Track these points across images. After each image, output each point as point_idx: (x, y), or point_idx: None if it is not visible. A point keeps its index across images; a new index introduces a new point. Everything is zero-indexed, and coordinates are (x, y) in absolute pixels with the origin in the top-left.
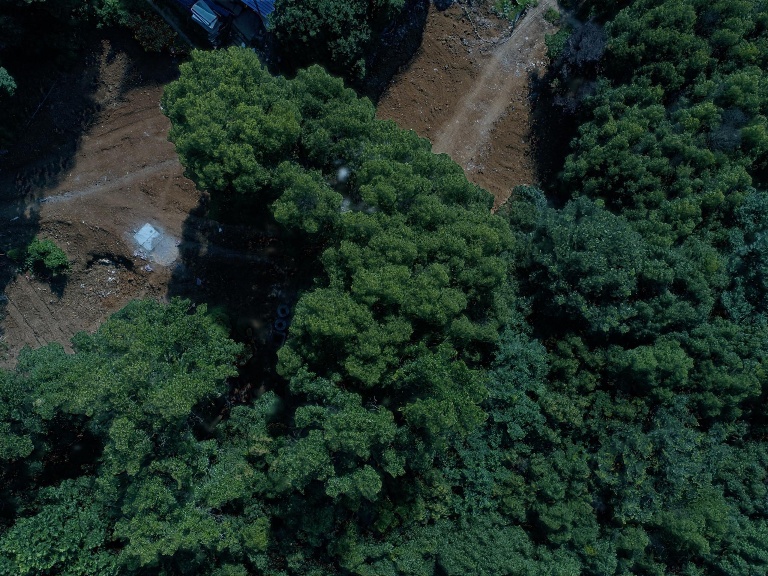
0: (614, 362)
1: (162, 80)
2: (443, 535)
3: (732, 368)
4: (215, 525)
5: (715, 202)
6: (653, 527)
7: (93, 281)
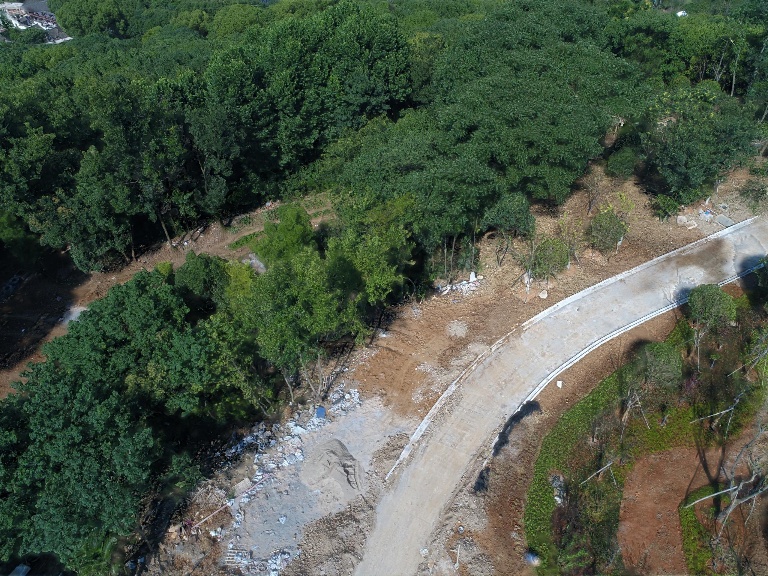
0: None
1: None
2: None
3: None
4: None
5: None
6: None
7: None
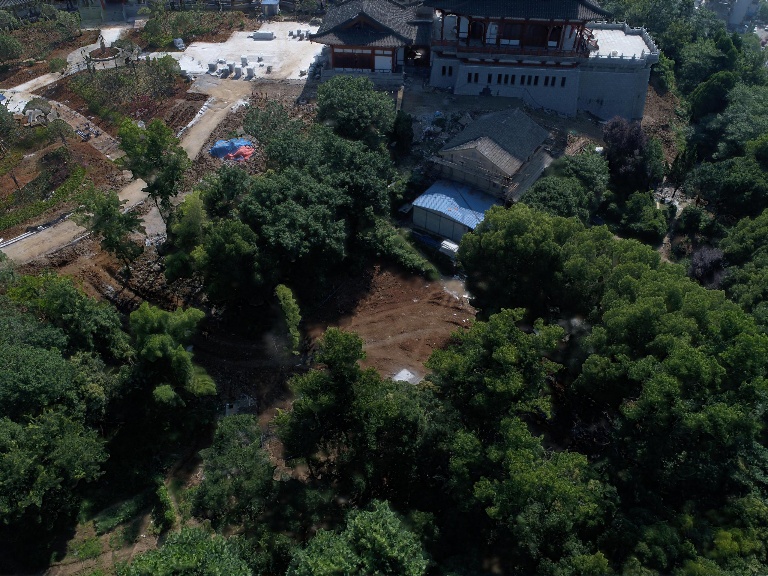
0: None
1: (414, 287)
2: None
3: None
4: None
5: None
6: None
7: None
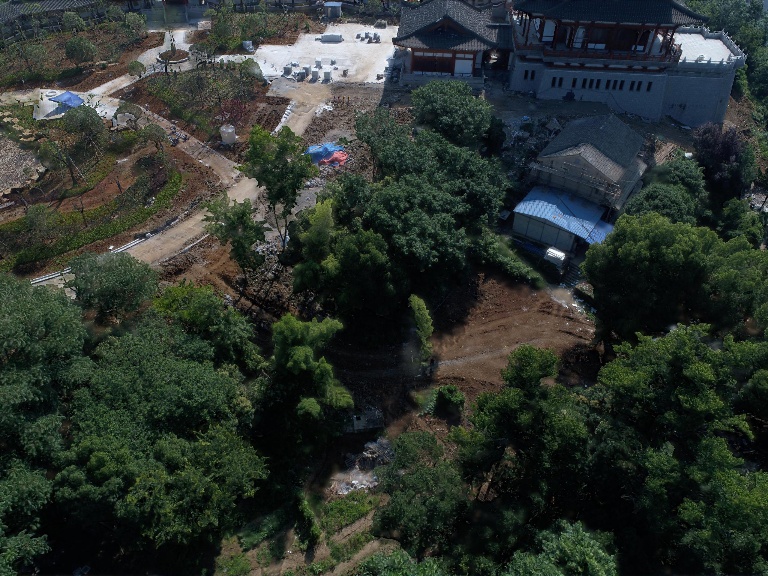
0: None
1: (521, 295)
2: None
3: None
4: None
5: None
6: None
7: None
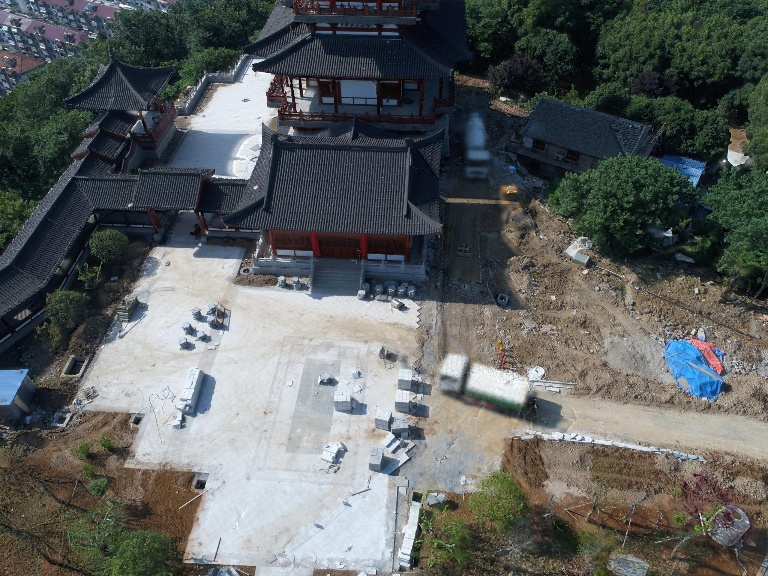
0: None
1: None
2: None
3: None
4: None
5: None
6: None
7: None
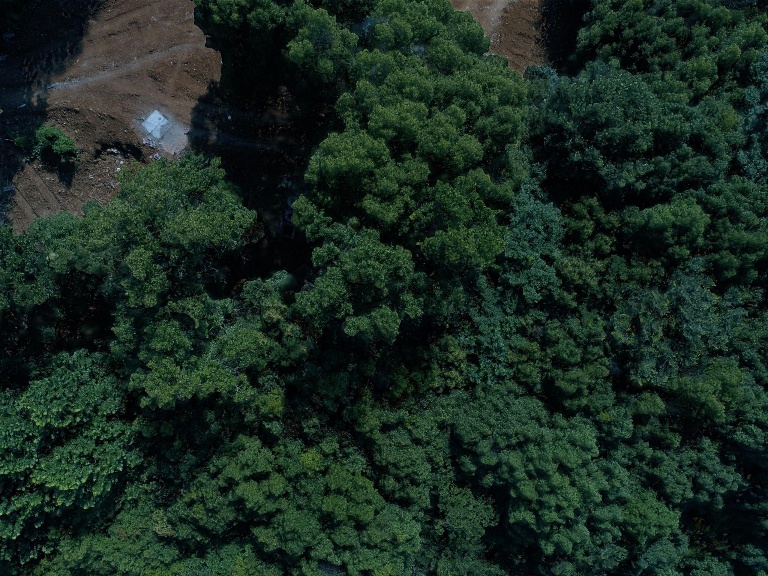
0: (630, 223)
1: None
2: (458, 406)
3: (748, 225)
4: (232, 376)
5: (731, 57)
6: (669, 393)
7: (101, 172)
